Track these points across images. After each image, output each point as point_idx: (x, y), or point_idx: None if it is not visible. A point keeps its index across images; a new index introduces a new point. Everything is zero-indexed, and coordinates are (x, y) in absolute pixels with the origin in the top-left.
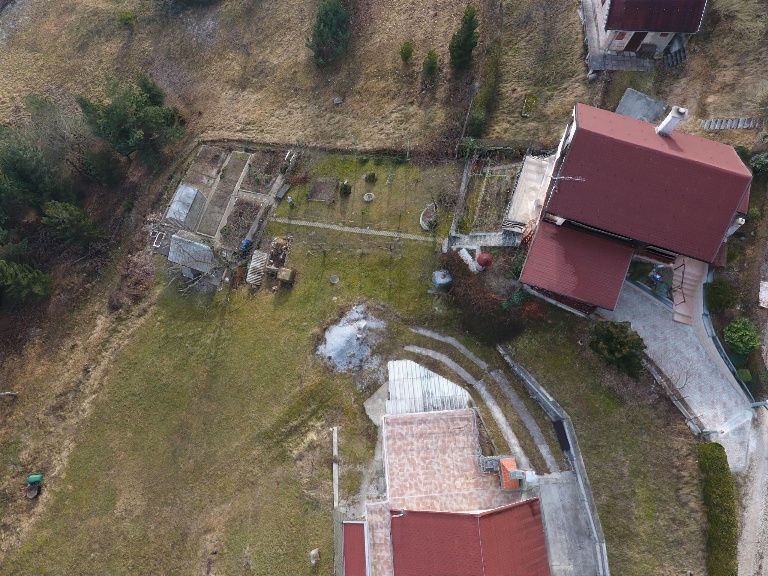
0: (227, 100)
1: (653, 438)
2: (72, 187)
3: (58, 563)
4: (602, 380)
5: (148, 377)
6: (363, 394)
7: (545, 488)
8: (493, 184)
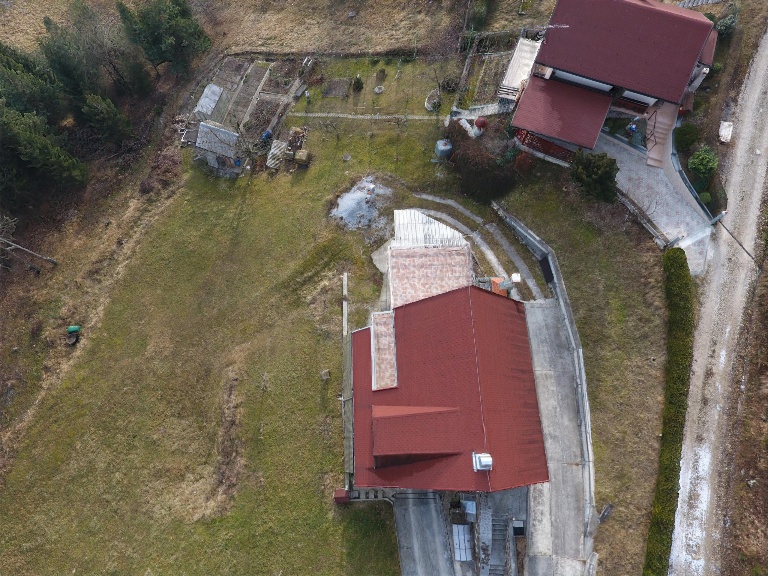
0: (250, 22)
1: (625, 257)
2: (107, 94)
3: (94, 396)
4: (583, 217)
5: (176, 245)
6: (371, 247)
7: (531, 311)
8: (491, 67)
